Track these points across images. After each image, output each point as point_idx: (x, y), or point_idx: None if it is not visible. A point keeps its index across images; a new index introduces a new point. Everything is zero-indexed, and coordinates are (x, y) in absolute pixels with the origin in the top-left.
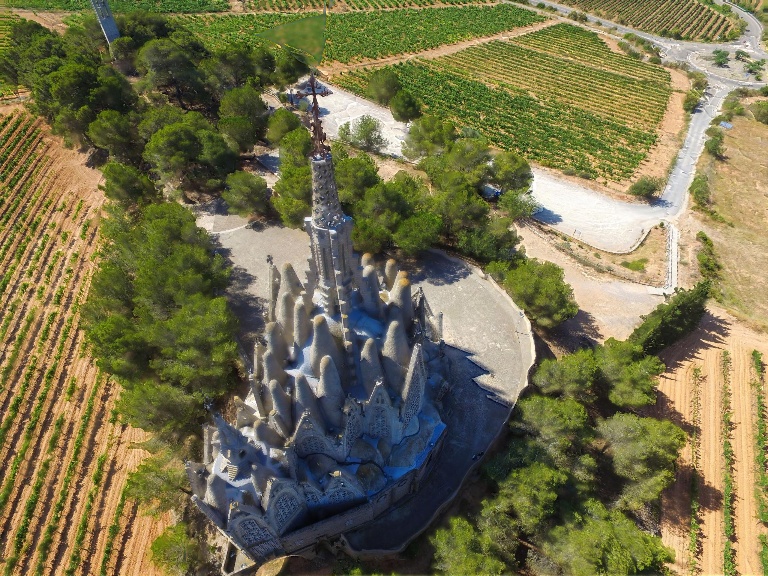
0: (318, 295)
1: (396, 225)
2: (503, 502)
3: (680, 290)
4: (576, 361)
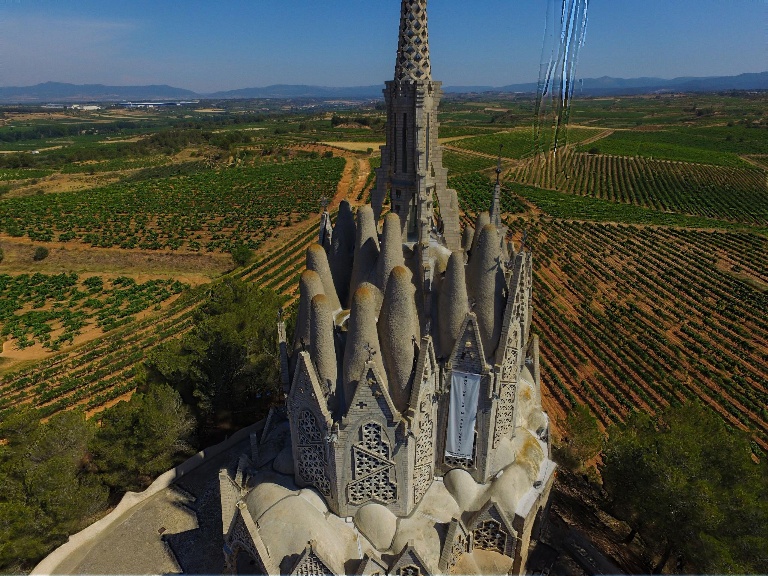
0: None
1: None
2: (263, 355)
3: None
4: (6, 521)
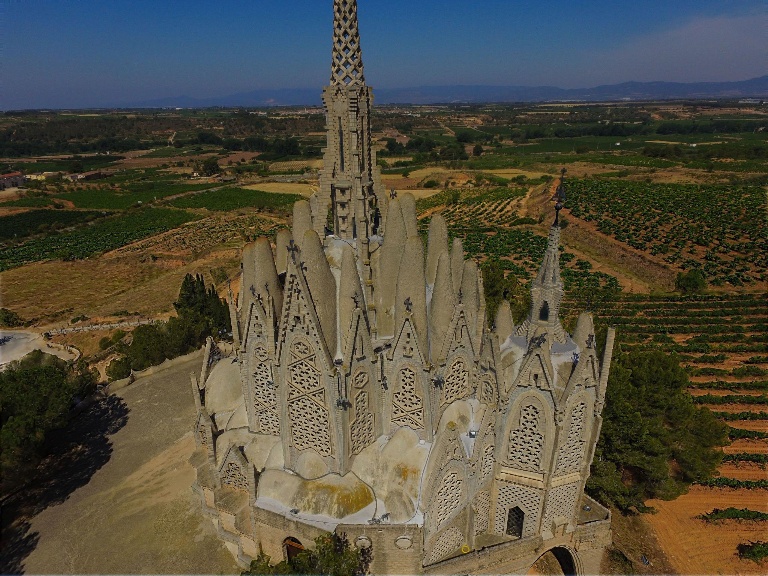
0: (339, 244)
1: (2, 414)
2: None
3: (176, 303)
4: None
